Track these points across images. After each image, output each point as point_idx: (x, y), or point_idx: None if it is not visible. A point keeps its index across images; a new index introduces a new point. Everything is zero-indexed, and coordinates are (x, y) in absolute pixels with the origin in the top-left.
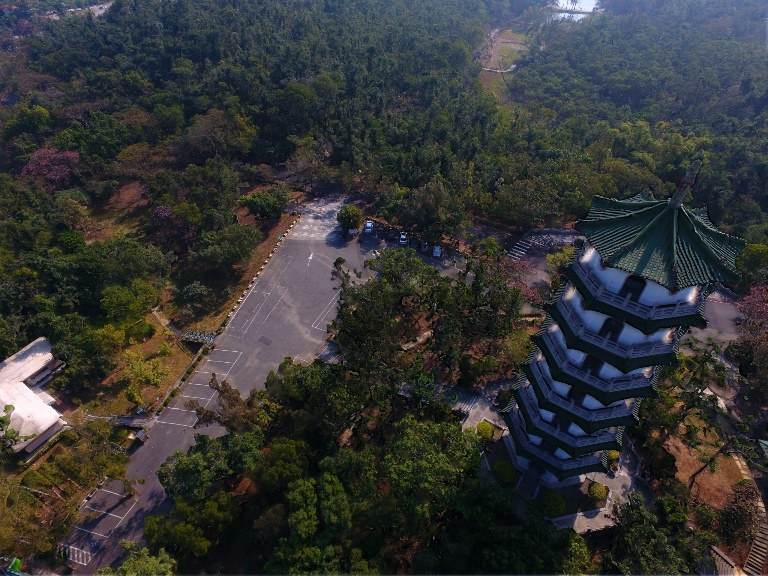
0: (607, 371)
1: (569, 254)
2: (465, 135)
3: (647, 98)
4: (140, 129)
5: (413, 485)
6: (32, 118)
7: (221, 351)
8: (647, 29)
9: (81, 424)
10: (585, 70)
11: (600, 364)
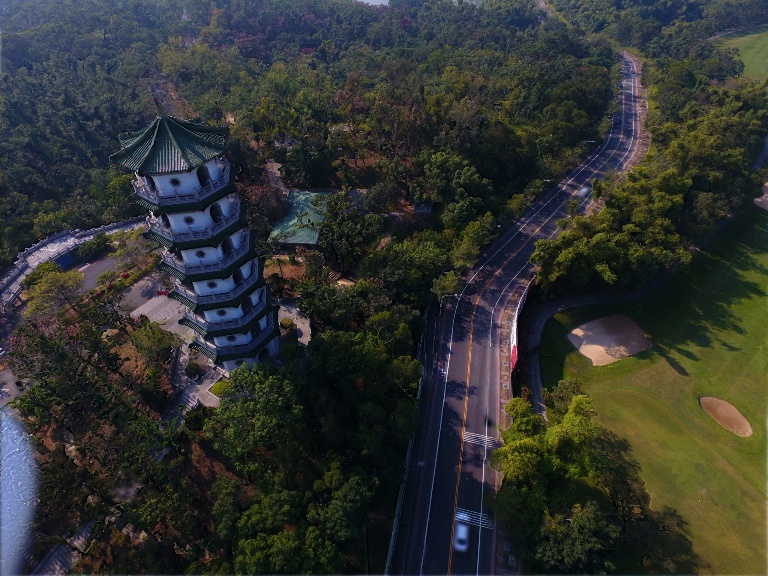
0: (236, 242)
1: (41, 292)
2: None
3: None
4: None
5: None
6: None
7: None
8: None
9: None
10: None
11: (230, 242)
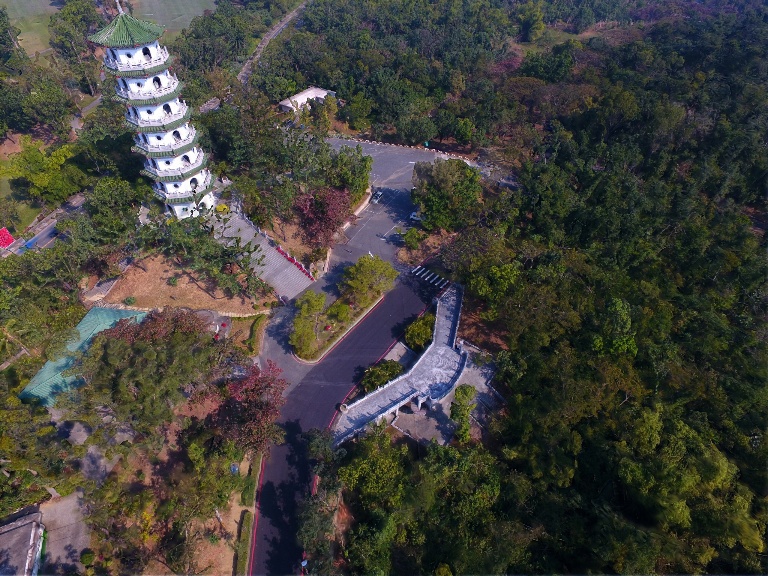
0: None
1: None
2: None
3: None
4: (571, 80)
5: None
6: (567, 47)
7: (326, 140)
8: None
9: (248, 80)
10: None
11: None
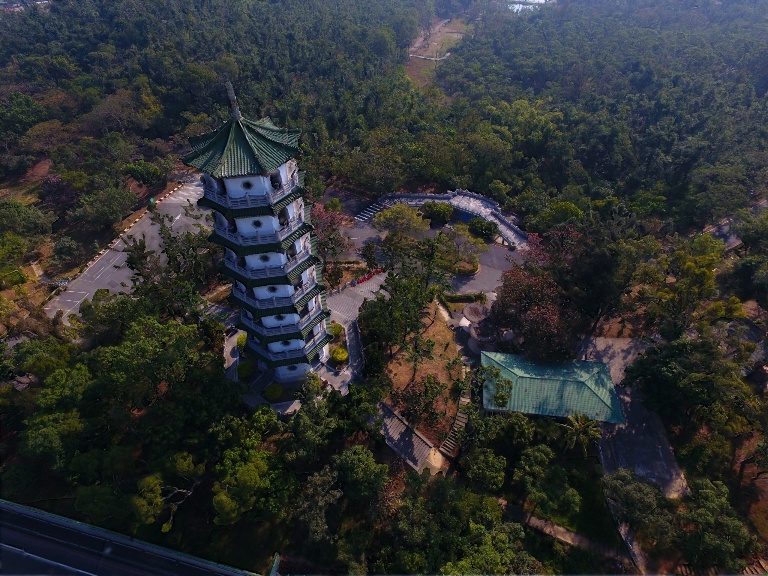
0: (249, 262)
1: (392, 210)
2: (344, 111)
3: (552, 81)
4: (58, 109)
5: (122, 362)
6: None
7: (71, 292)
8: (577, 18)
9: None
10: (506, 56)
11: (243, 257)
